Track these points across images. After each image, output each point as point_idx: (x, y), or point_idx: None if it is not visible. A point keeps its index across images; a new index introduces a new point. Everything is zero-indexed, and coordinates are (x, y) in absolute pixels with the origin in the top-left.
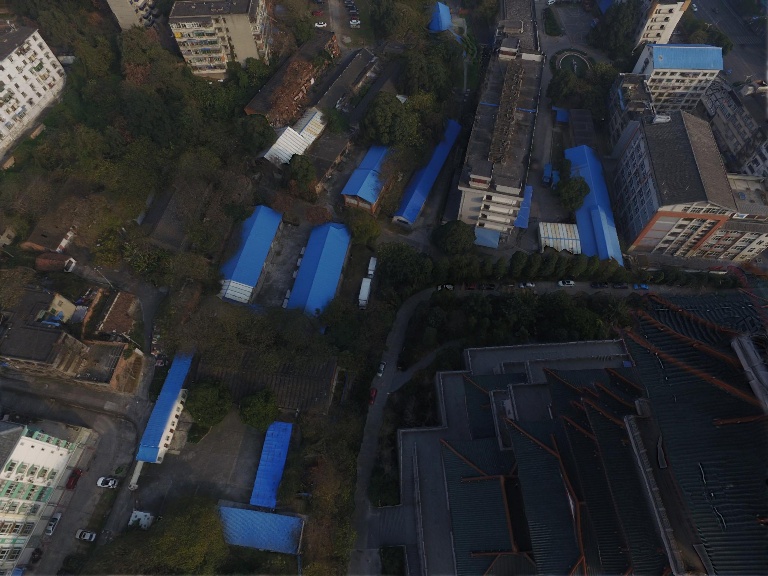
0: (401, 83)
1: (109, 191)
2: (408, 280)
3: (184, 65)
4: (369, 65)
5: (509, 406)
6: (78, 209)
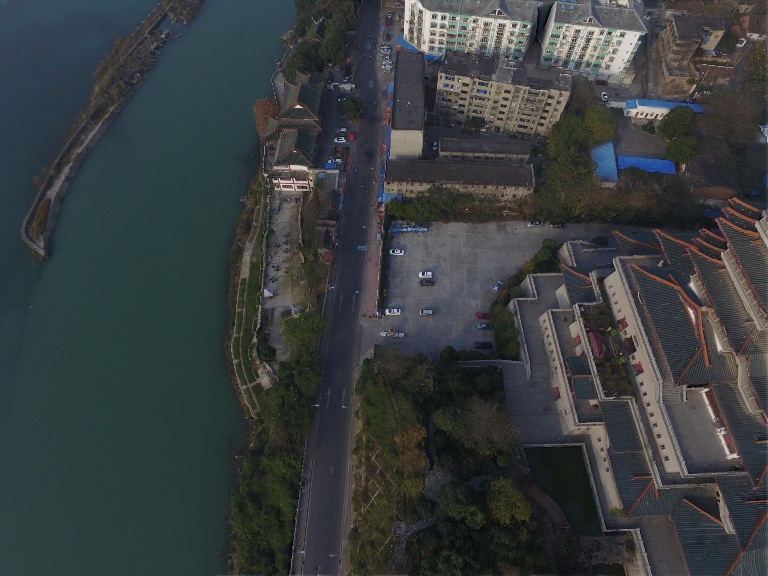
0: None
1: None
2: None
3: None
4: None
5: None
6: None
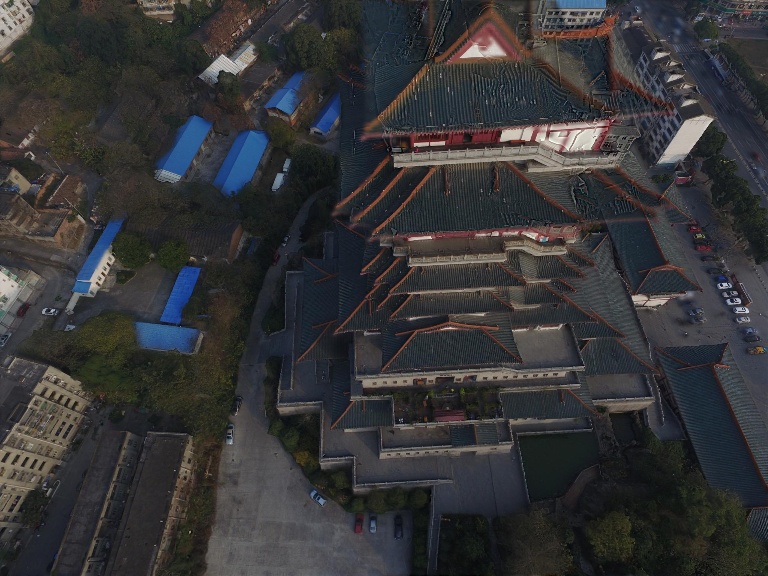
0: (325, 22)
1: (63, 98)
2: (313, 173)
3: (137, 6)
4: (301, 9)
5: None
6: (34, 106)
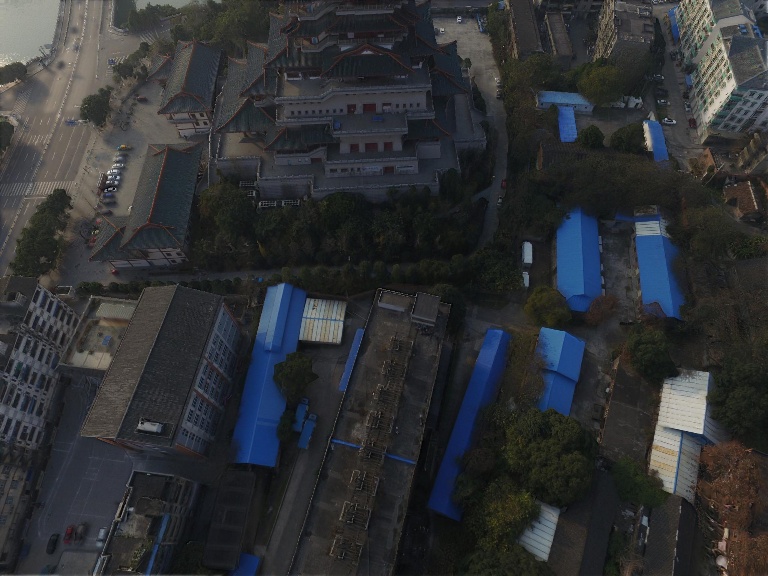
0: (548, 570)
1: None
2: None
3: None
4: None
5: None
6: None
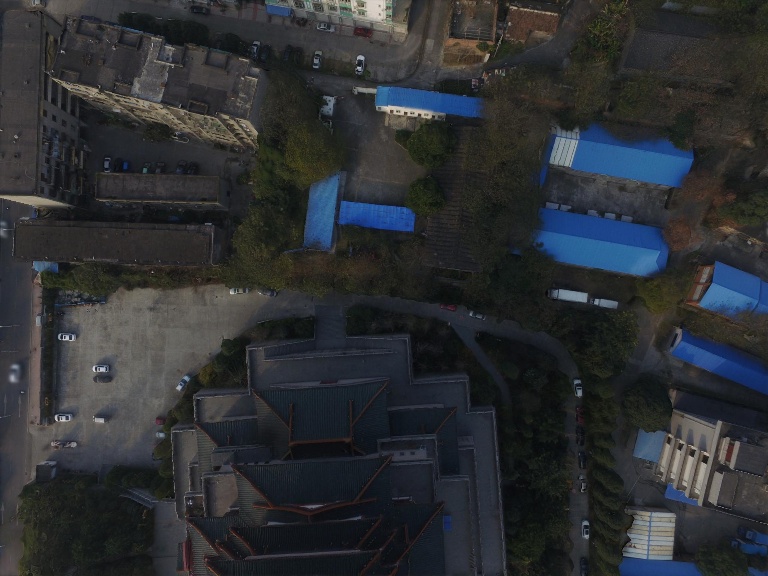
0: None
1: None
2: (584, 347)
3: None
4: None
5: (418, 454)
6: None
